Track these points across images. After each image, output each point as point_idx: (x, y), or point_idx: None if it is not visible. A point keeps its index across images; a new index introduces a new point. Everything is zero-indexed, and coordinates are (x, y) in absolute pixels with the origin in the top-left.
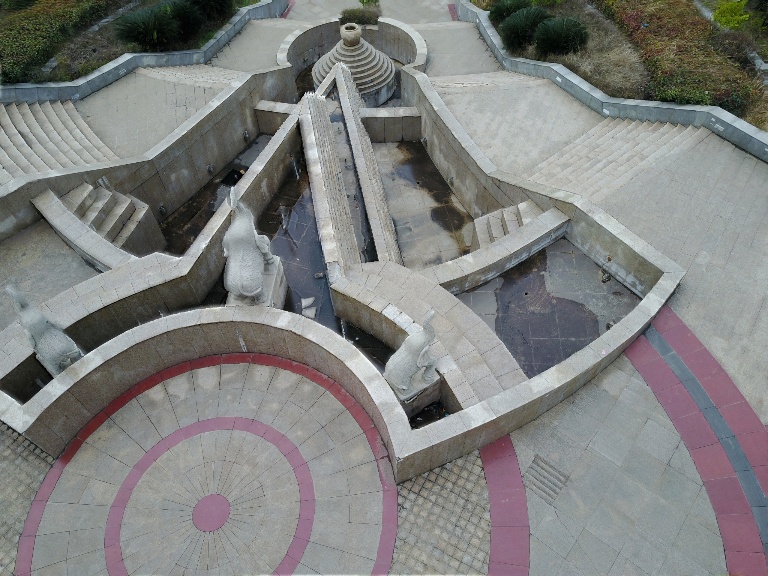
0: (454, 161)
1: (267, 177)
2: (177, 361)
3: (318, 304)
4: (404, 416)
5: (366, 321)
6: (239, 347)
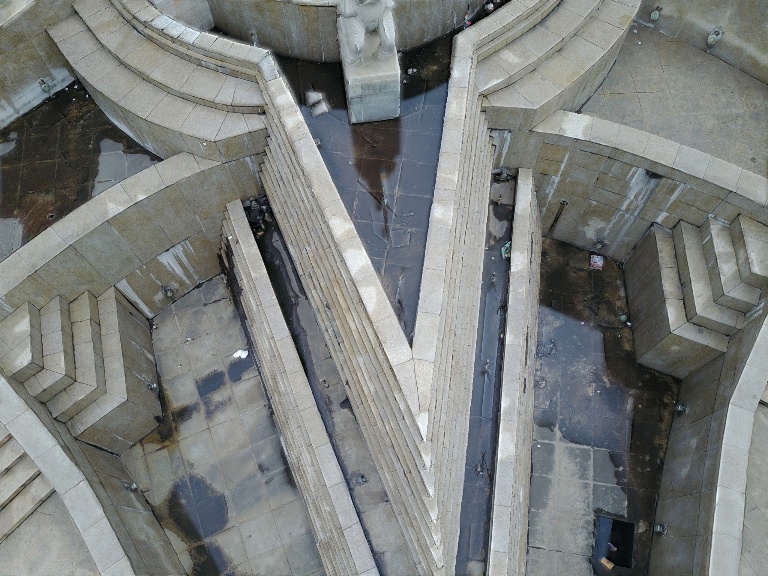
0: None
1: None
2: None
3: (306, 110)
4: None
5: None
6: None
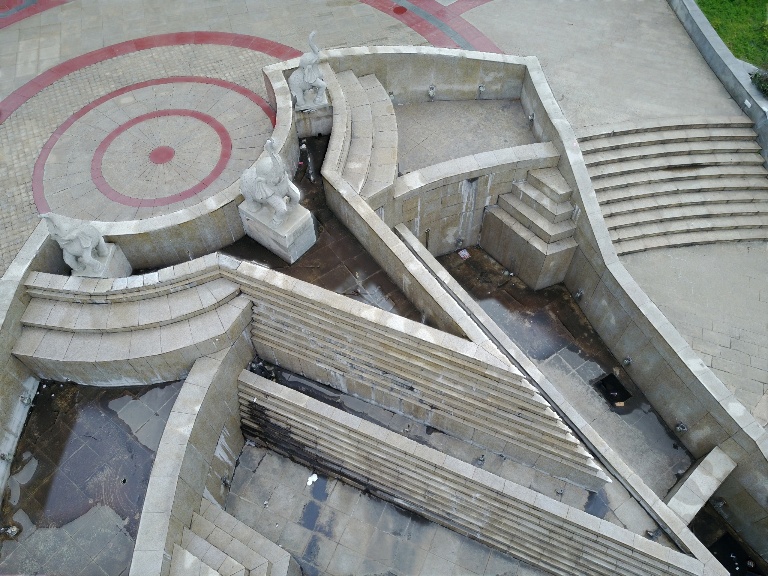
0: None
1: None
2: None
3: None
4: None
5: None
6: None
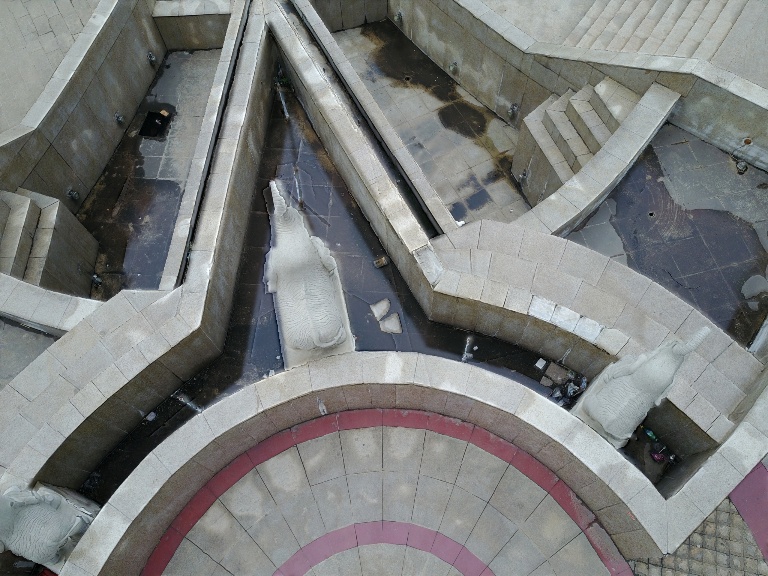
0: (458, 40)
1: (250, 127)
2: (228, 460)
3: (397, 308)
4: (645, 481)
5: (491, 324)
6: (316, 412)
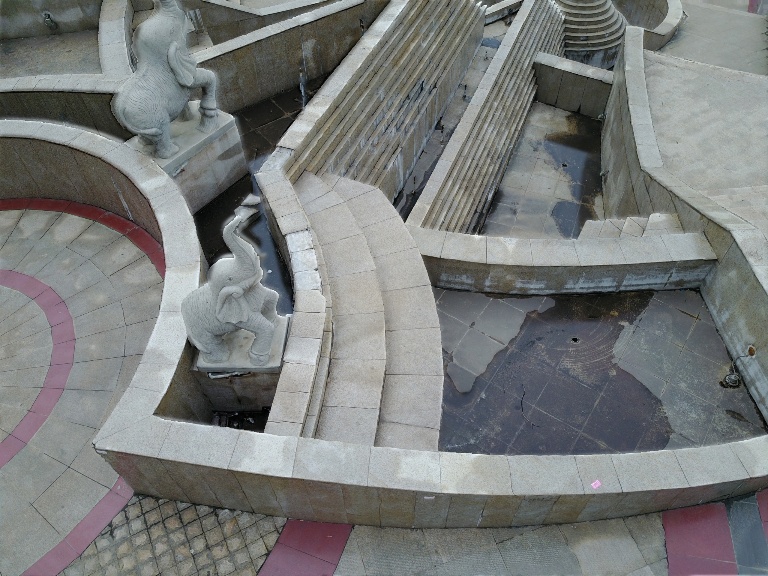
0: (617, 146)
1: (317, 40)
2: (56, 194)
3: None
4: (163, 388)
5: (282, 248)
6: (124, 209)
